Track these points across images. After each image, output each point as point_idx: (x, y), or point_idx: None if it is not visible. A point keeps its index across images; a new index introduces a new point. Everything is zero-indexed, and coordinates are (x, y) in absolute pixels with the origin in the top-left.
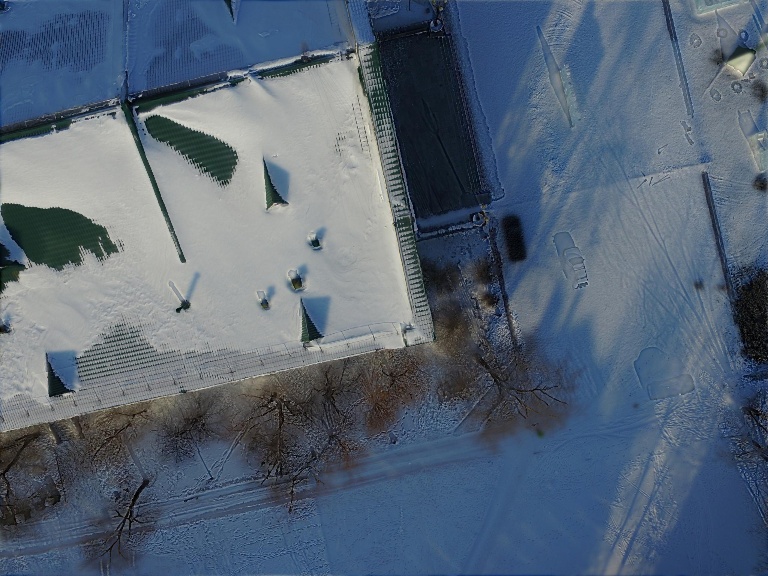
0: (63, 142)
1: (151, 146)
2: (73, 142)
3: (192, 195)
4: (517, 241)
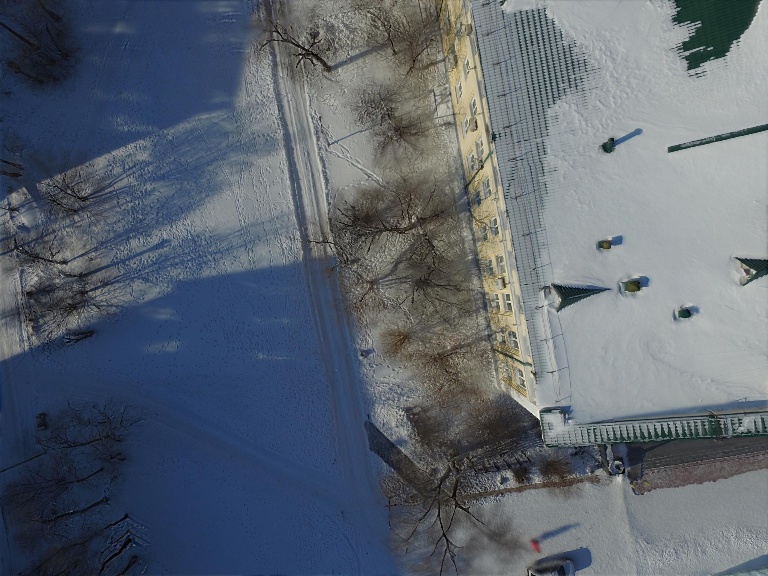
0: None
1: None
2: None
3: (766, 168)
4: (584, 506)
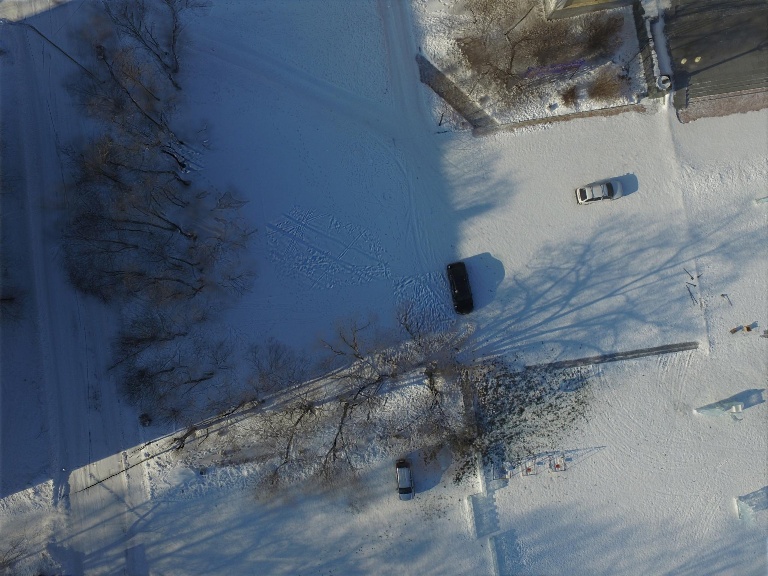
0: None
1: None
2: None
3: None
4: (630, 134)
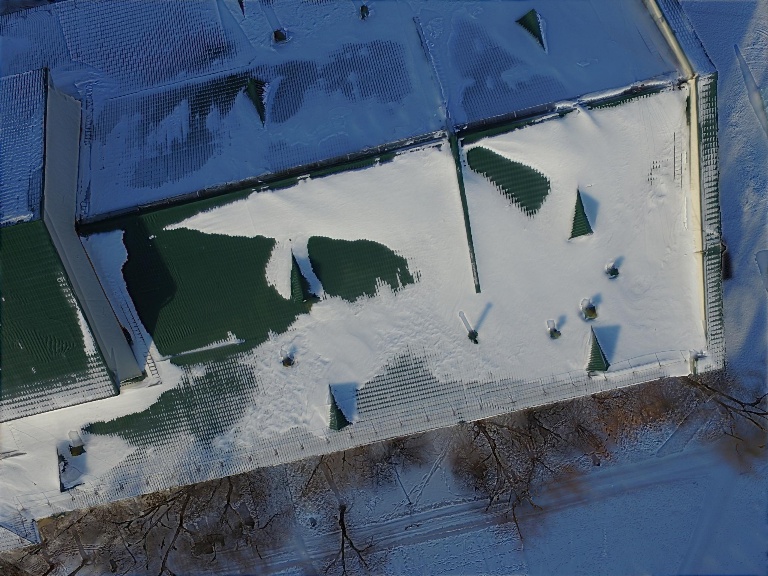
0: (385, 175)
1: (469, 177)
2: (395, 174)
3: (499, 225)
4: None
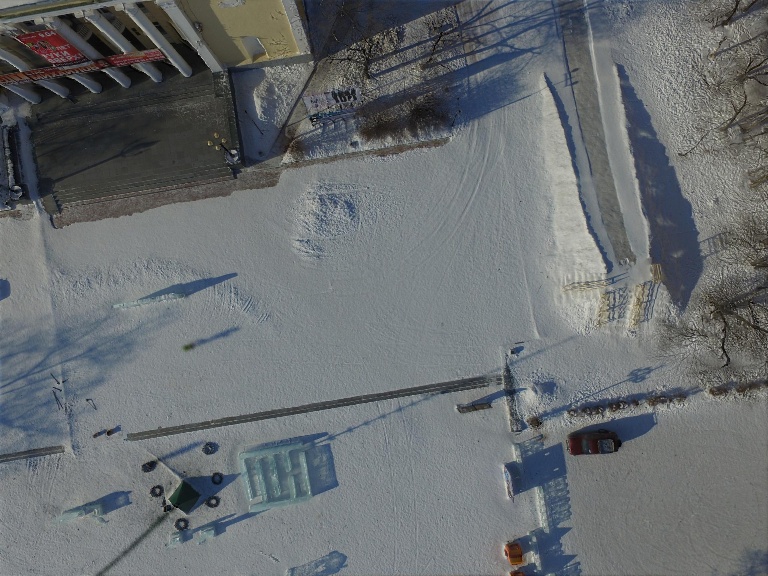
0: None
1: None
2: None
3: None
4: (5, 240)
